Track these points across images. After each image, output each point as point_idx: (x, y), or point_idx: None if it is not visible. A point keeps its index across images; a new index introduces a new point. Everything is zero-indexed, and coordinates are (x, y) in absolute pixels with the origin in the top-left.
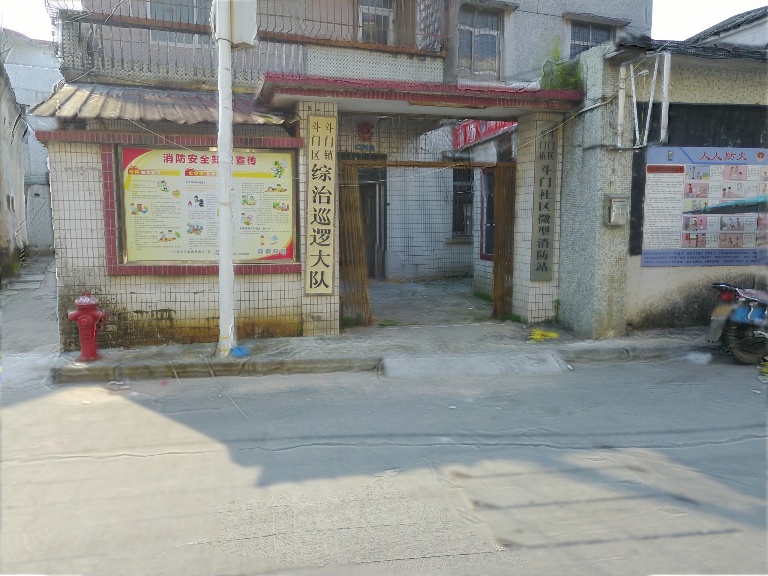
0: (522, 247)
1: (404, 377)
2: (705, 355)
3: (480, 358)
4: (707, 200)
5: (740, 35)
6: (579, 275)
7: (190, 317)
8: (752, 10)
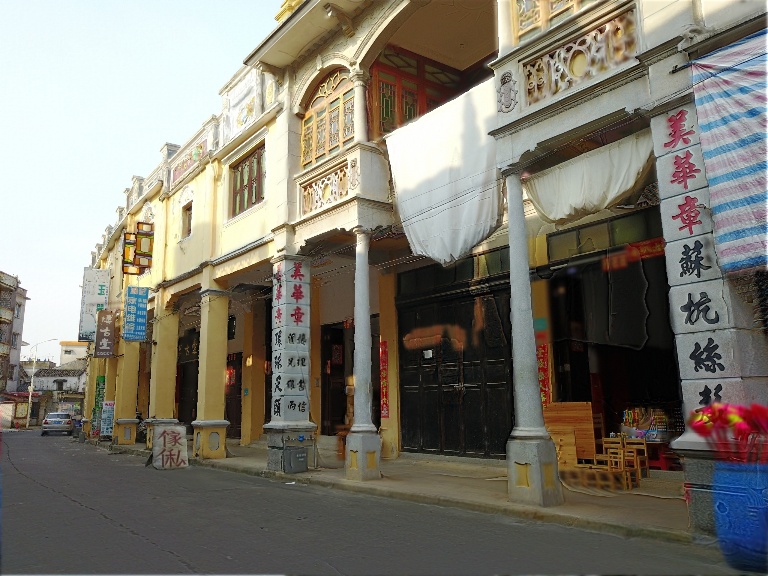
0: (41, 415)
1: None
2: None
3: None
4: None
5: (48, 377)
6: None
7: (18, 424)
8: (44, 369)
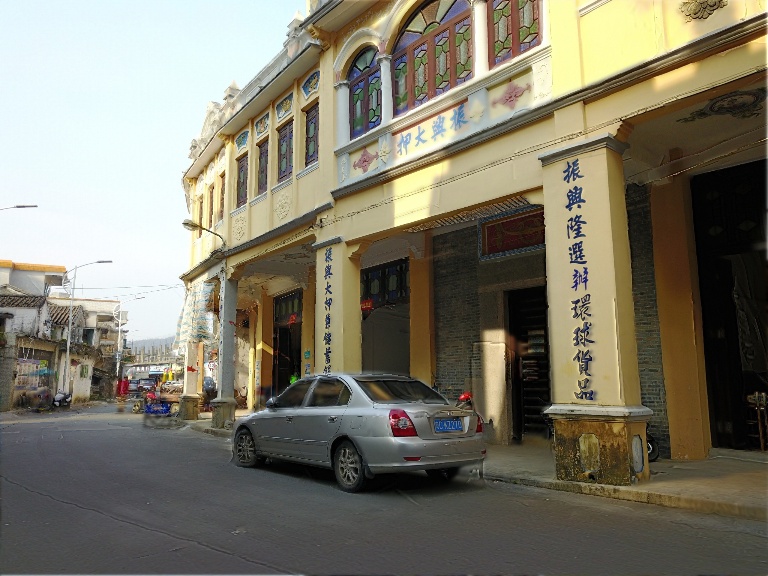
0: None
1: (0, 418)
2: (30, 412)
3: (3, 414)
4: (21, 372)
5: None
6: (0, 393)
7: None
8: None
